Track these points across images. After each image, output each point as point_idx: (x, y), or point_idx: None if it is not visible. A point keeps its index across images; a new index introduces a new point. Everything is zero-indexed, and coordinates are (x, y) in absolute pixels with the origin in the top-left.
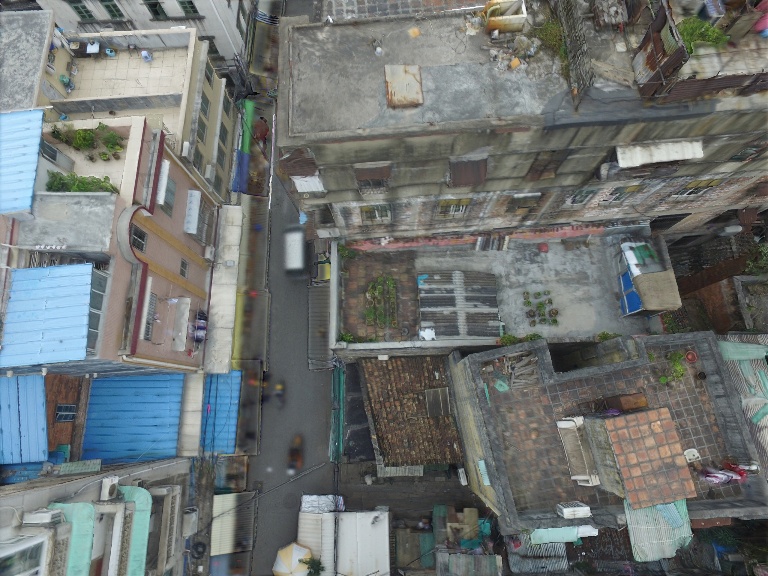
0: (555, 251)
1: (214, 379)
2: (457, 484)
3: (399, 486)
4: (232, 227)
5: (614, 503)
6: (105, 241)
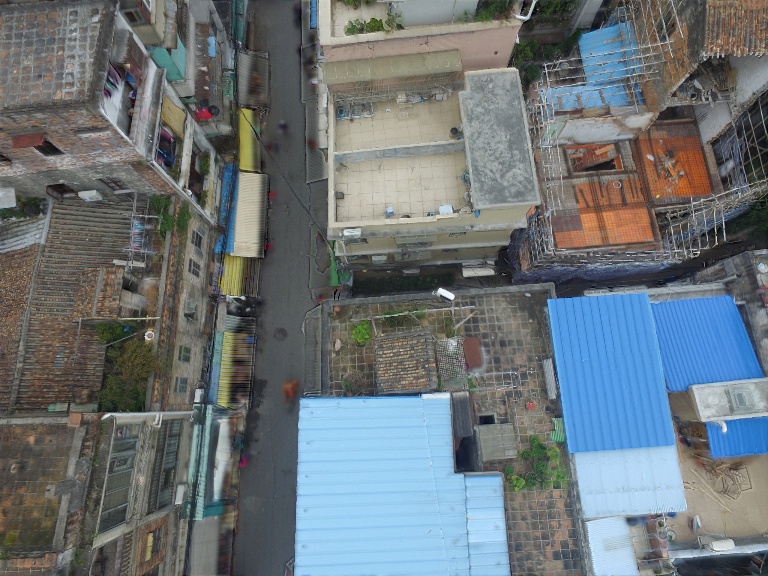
0: None
1: None
2: None
3: None
4: (326, 128)
5: None
6: None
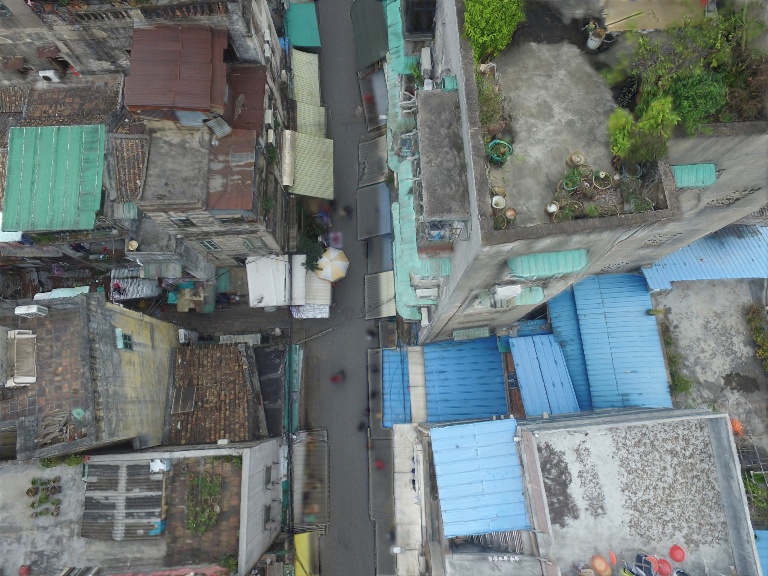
0: (14, 568)
1: (409, 418)
2: (205, 330)
3: (255, 327)
4: None
5: (8, 318)
6: (451, 568)
